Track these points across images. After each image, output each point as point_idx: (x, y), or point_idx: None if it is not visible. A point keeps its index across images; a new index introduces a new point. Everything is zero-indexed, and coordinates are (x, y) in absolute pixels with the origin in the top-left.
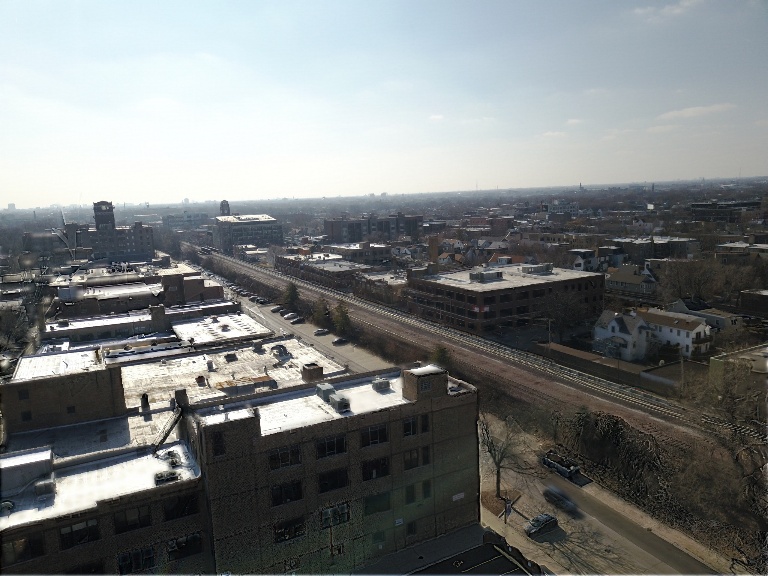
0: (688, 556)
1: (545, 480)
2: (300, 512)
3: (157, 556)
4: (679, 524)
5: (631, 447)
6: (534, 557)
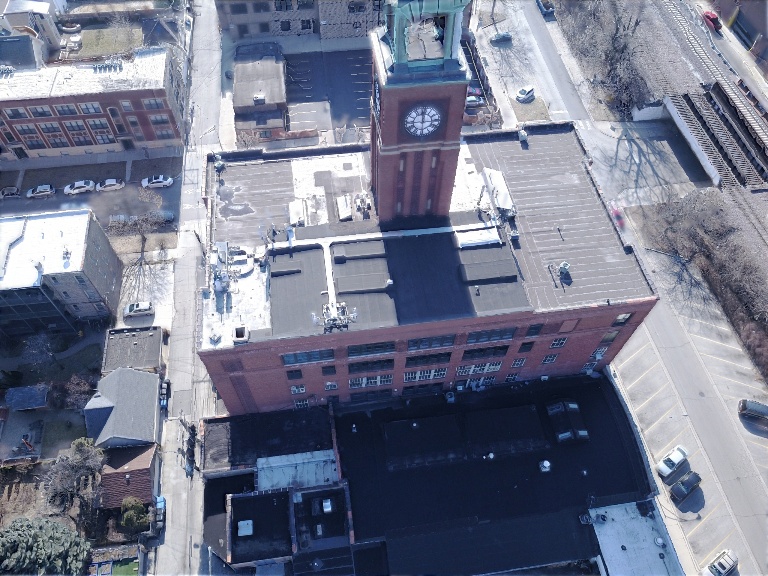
0: (566, 72)
1: (528, 13)
2: None
3: (293, 5)
4: (580, 56)
5: (582, 4)
6: (483, 52)
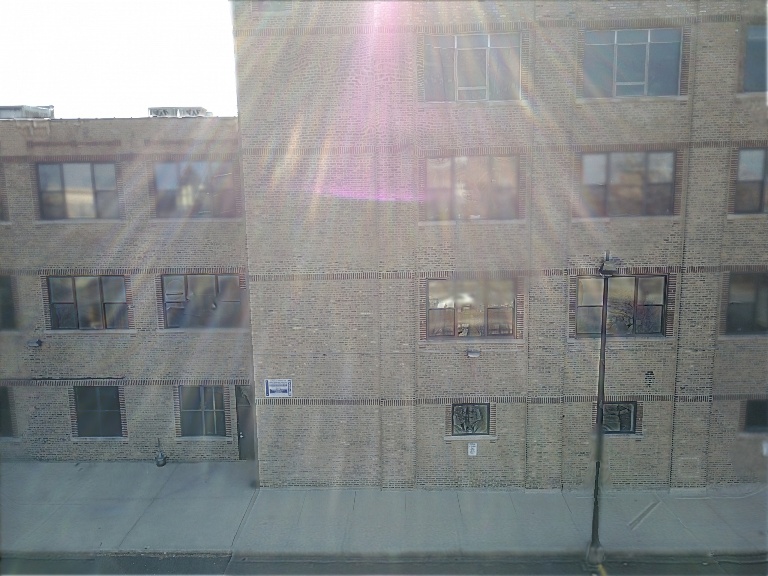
0: None
1: None
2: (508, 261)
3: (136, 305)
4: None
5: None
6: None
